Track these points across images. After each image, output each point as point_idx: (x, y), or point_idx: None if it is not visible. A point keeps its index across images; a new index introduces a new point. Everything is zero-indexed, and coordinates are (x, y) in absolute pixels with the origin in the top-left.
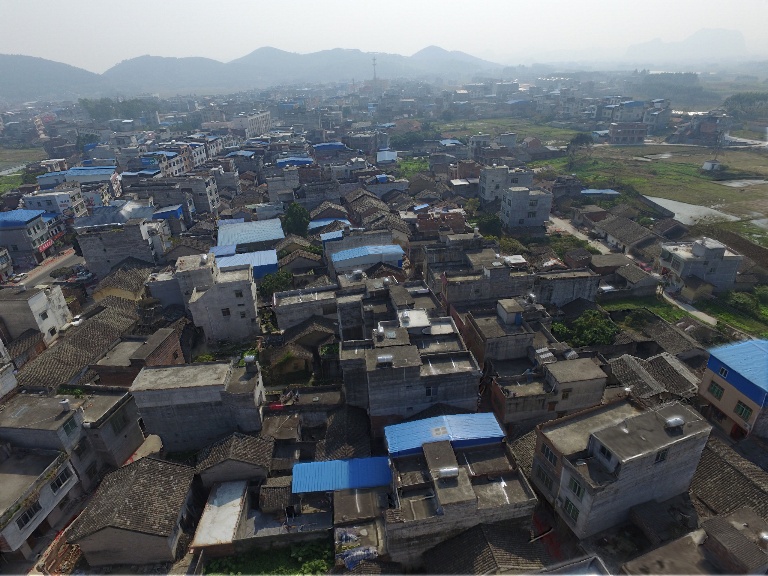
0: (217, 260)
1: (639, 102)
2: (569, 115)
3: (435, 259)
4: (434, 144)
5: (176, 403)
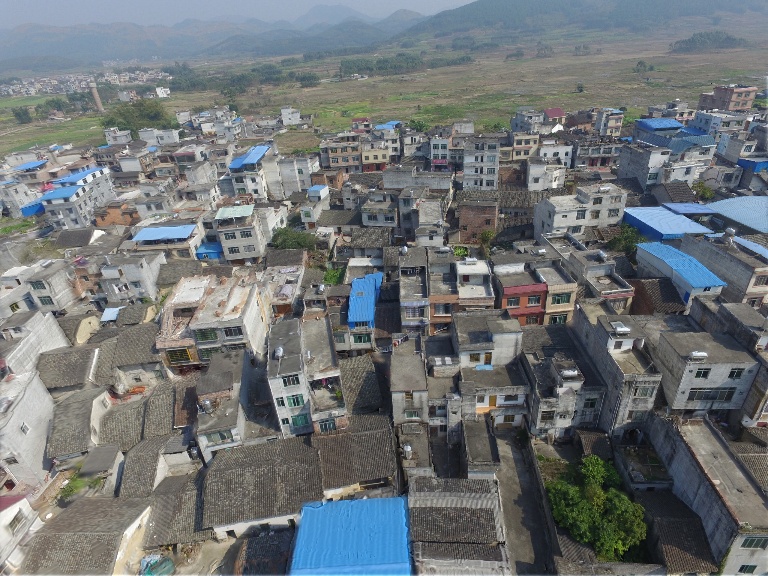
0: (658, 209)
1: None
2: None
3: (698, 315)
4: None
5: None
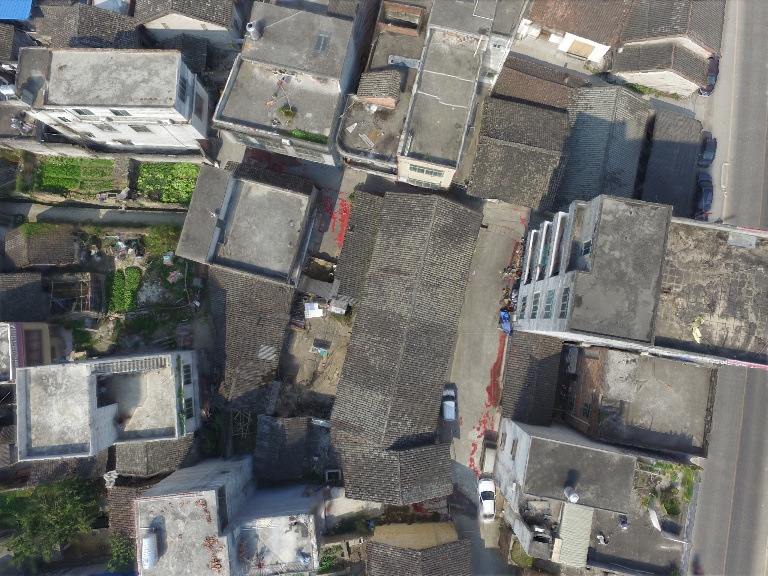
0: None
1: None
2: None
3: None
4: None
5: None
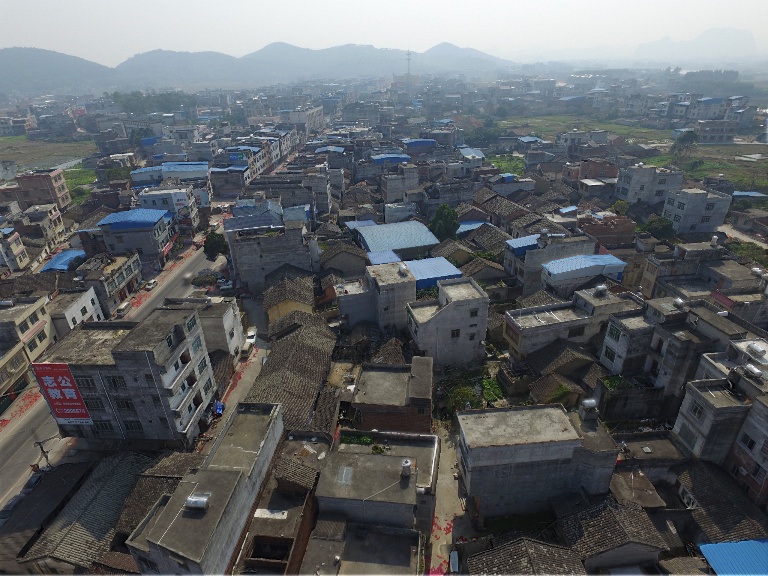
0: None
1: (717, 99)
2: (633, 112)
3: (666, 272)
4: (509, 141)
5: (518, 461)
